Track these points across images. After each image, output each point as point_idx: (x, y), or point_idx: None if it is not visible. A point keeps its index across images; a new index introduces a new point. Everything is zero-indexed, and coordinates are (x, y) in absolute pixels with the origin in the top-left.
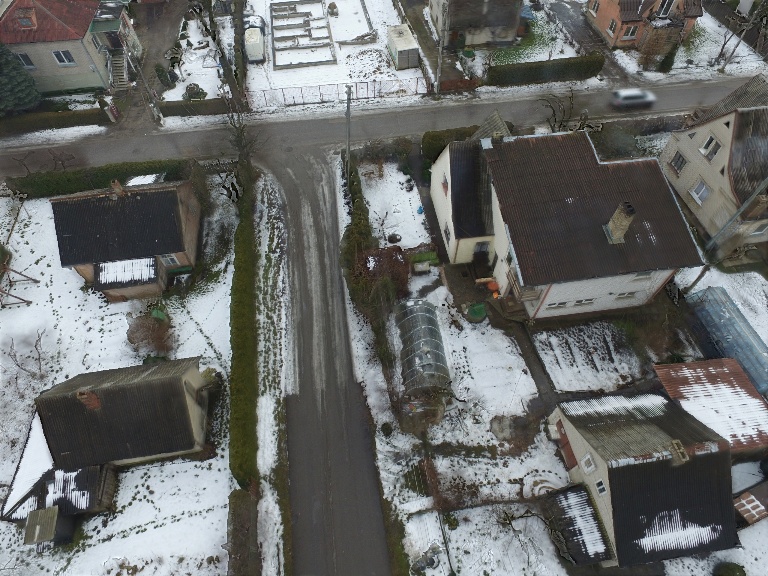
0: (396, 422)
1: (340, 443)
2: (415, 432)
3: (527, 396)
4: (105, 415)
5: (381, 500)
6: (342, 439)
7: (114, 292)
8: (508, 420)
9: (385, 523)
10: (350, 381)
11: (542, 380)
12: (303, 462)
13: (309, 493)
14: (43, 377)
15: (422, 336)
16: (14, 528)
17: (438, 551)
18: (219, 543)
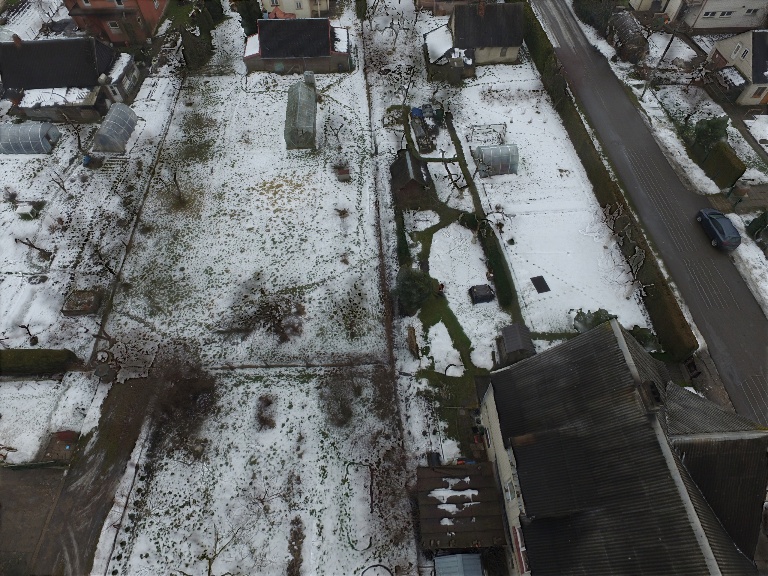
0: (619, 58)
1: (589, 63)
2: (633, 57)
3: (691, 56)
4: (484, 19)
5: (617, 79)
6: (590, 62)
7: (442, 6)
8: (683, 59)
9: (621, 86)
10: (588, 45)
11: (699, 52)
12: (571, 67)
13: (578, 76)
14: (413, 38)
15: (631, 23)
16: (426, 81)
17: (692, 5)
18: (536, 88)
